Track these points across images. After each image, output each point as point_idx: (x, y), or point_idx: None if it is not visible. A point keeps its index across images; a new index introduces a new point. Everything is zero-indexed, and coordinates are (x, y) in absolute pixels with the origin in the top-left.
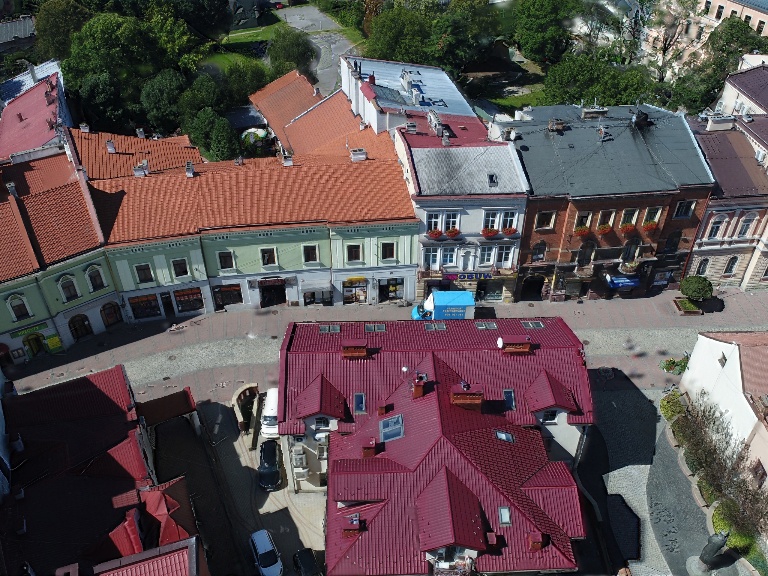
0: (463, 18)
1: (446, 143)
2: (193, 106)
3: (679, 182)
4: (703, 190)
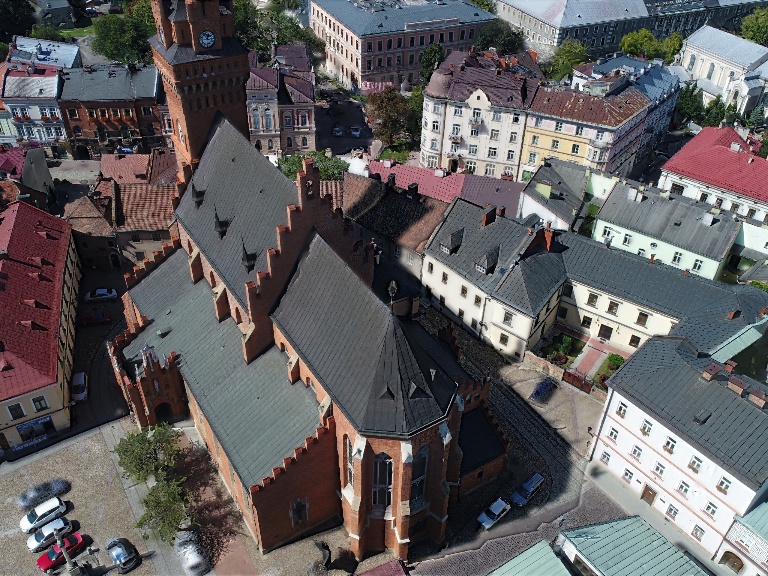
0: (138, 21)
1: (27, 75)
2: None
3: (137, 96)
4: (152, 101)
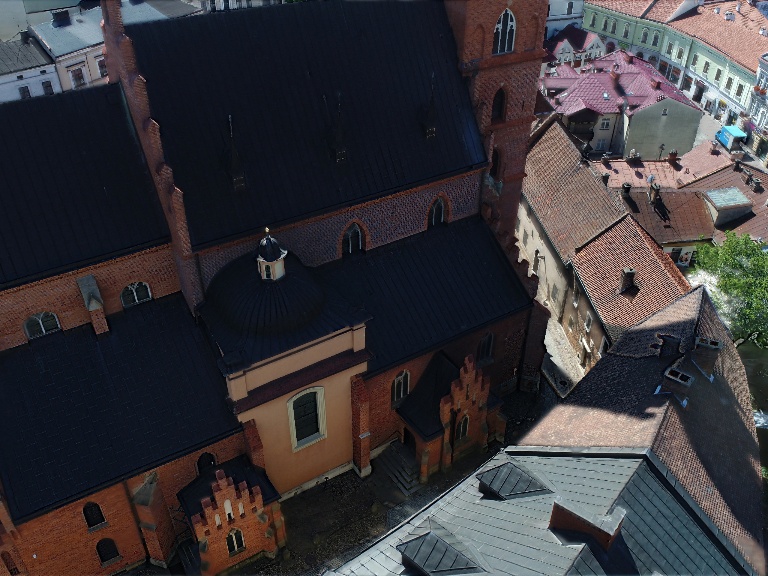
0: None
1: None
2: None
3: None
4: None
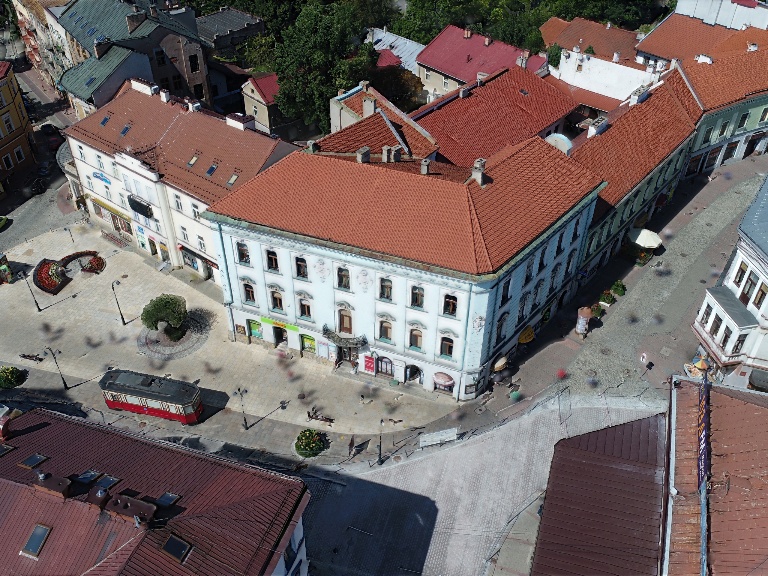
0: None
1: None
2: (536, 45)
3: None
4: None
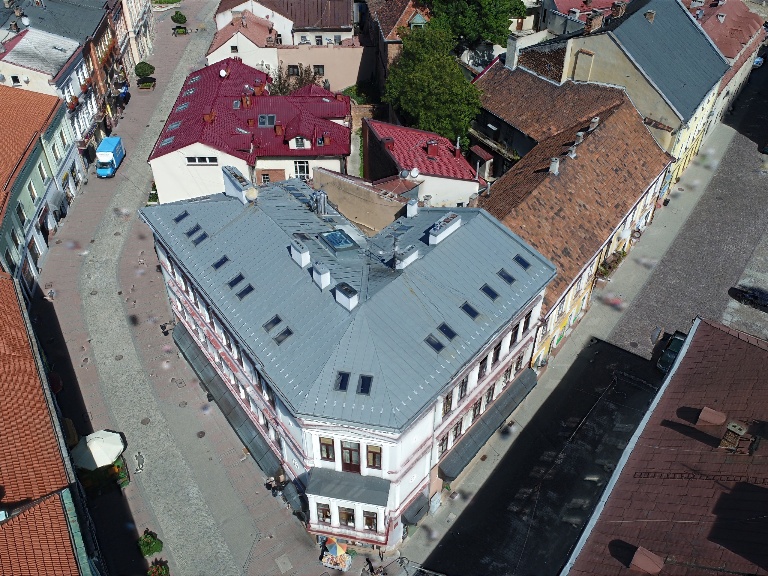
0: None
1: (4, 49)
2: None
3: (100, 7)
4: None
